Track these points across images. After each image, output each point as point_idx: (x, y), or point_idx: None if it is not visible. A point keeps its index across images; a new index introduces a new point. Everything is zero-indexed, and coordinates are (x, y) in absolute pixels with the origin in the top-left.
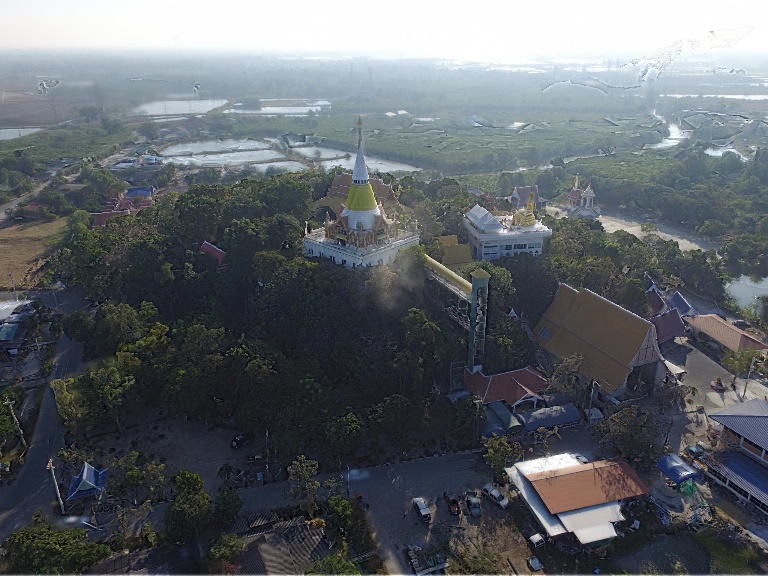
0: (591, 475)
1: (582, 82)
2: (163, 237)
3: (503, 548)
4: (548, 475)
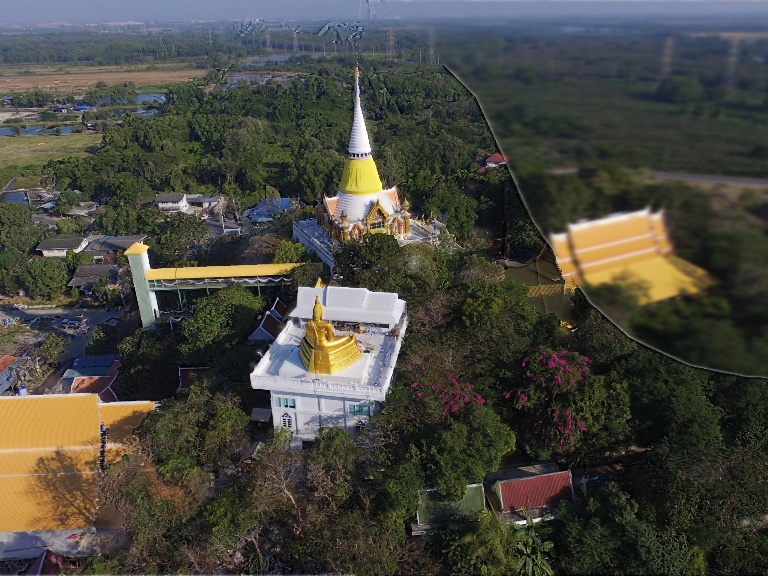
0: None
1: (233, 34)
2: (468, 176)
3: (3, 349)
4: None
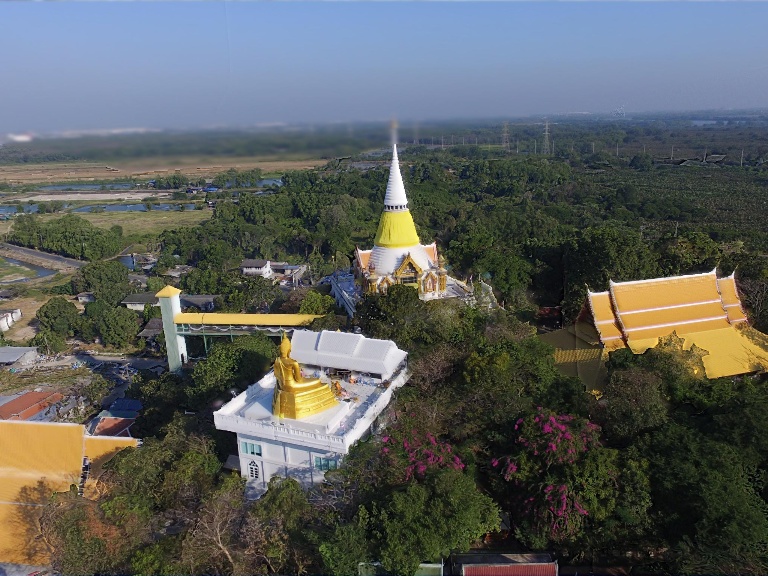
0: (7, 416)
1: None
2: None
3: None
4: (46, 401)
